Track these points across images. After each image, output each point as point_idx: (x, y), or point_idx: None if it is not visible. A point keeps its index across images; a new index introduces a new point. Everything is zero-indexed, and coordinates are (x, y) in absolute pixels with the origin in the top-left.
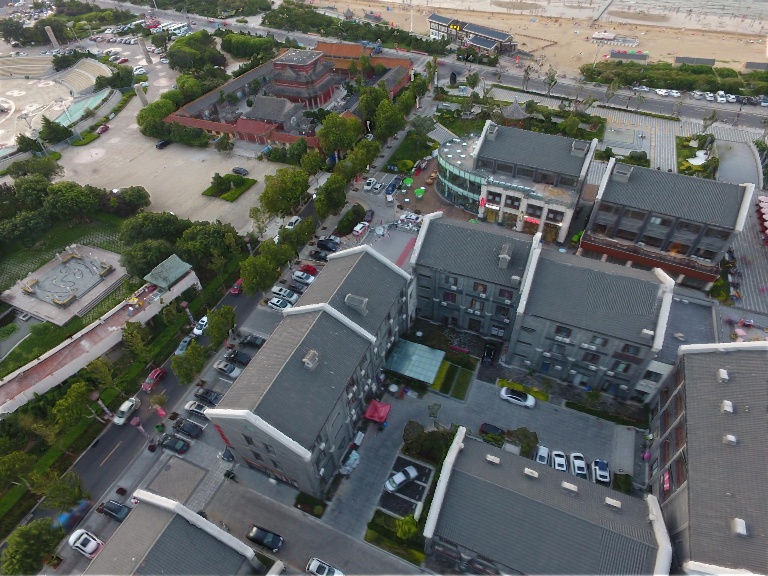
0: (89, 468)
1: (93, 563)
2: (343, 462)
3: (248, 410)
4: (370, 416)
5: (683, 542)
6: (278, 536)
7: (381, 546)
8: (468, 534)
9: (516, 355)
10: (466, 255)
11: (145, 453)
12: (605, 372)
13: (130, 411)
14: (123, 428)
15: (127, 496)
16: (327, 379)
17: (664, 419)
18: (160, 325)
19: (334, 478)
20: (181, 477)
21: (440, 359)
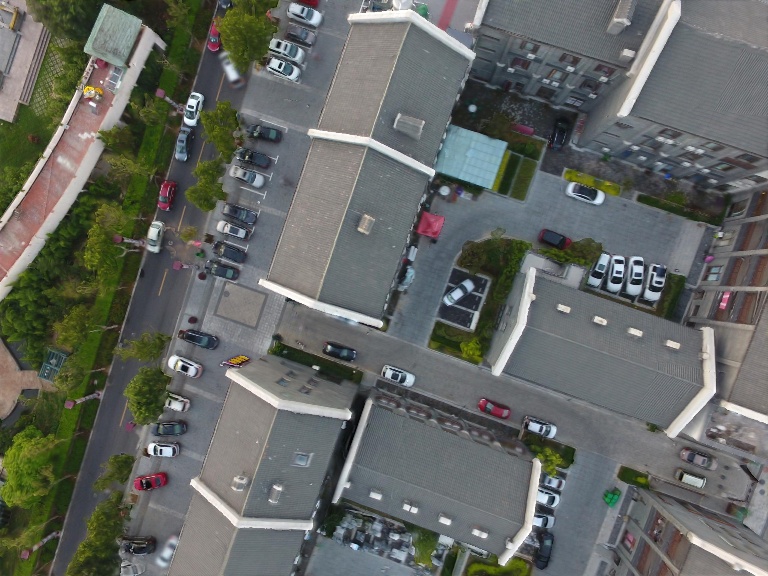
0: (149, 299)
1: (218, 429)
2: (399, 278)
3: (314, 301)
4: (423, 232)
5: (725, 375)
6: (351, 350)
7: (443, 352)
8: (532, 372)
9: (594, 141)
10: (560, 8)
11: (197, 280)
12: (699, 169)
13: (160, 238)
14: (161, 255)
15: (200, 323)
16: (386, 238)
17: (747, 230)
18: (138, 116)
19: (392, 294)
20: (243, 302)
21: (501, 154)
